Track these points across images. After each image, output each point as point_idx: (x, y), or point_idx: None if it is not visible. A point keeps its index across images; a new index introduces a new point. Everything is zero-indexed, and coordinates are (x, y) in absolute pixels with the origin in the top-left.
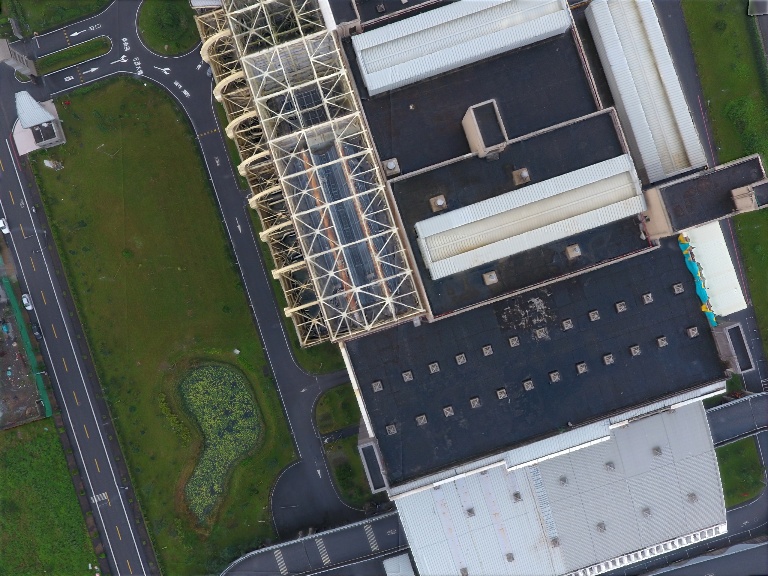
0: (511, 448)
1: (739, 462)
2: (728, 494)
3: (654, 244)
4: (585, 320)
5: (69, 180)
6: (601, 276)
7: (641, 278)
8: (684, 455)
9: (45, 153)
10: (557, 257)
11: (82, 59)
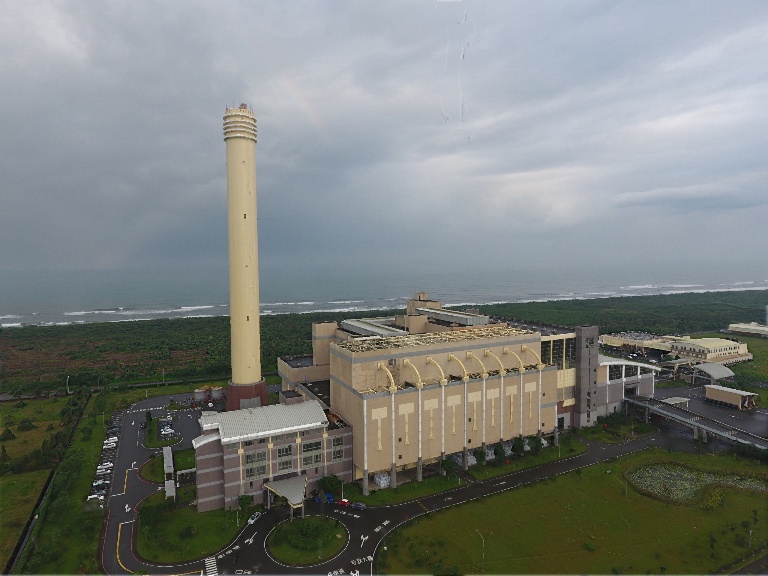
0: (545, 324)
1: None
2: None
3: None
4: None
5: None
6: None
7: None
8: None
9: None
10: None
11: None
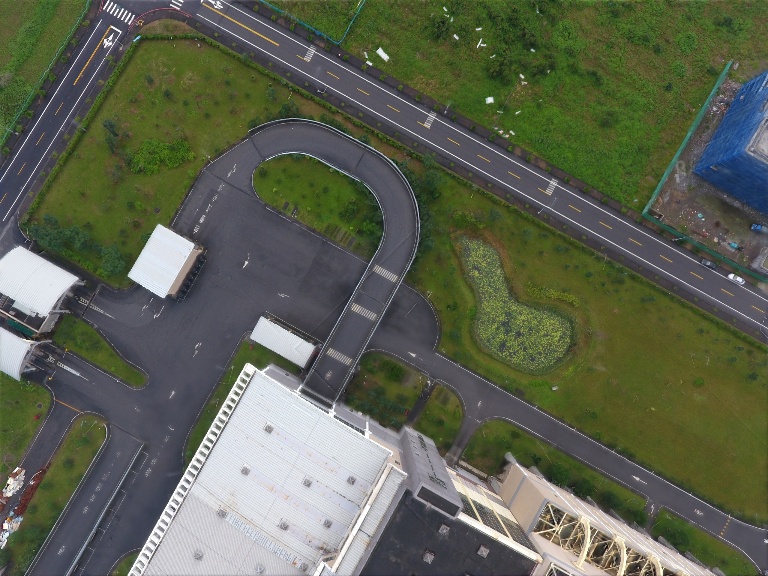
0: None
1: None
2: None
3: None
4: None
5: None
6: None
7: None
8: None
9: None
10: None
11: None
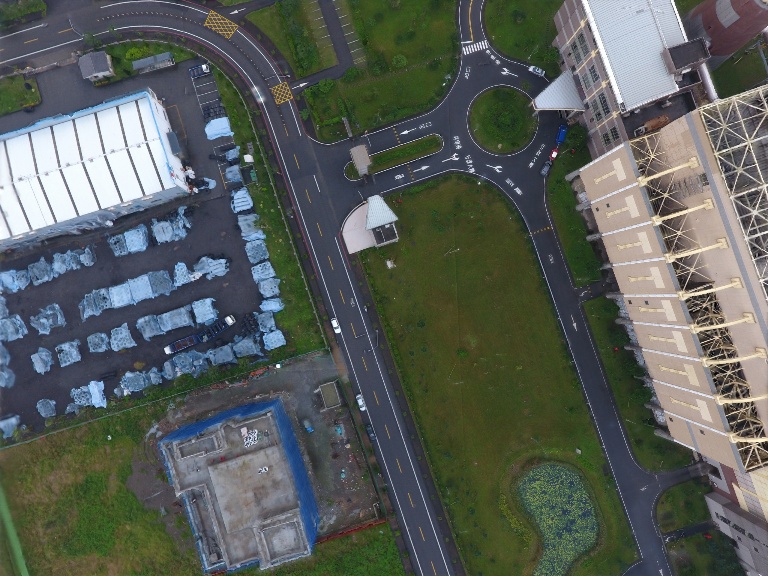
0: None
1: None
2: None
3: None
4: None
5: (401, 279)
6: None
7: None
8: None
9: (385, 254)
10: None
11: (413, 157)
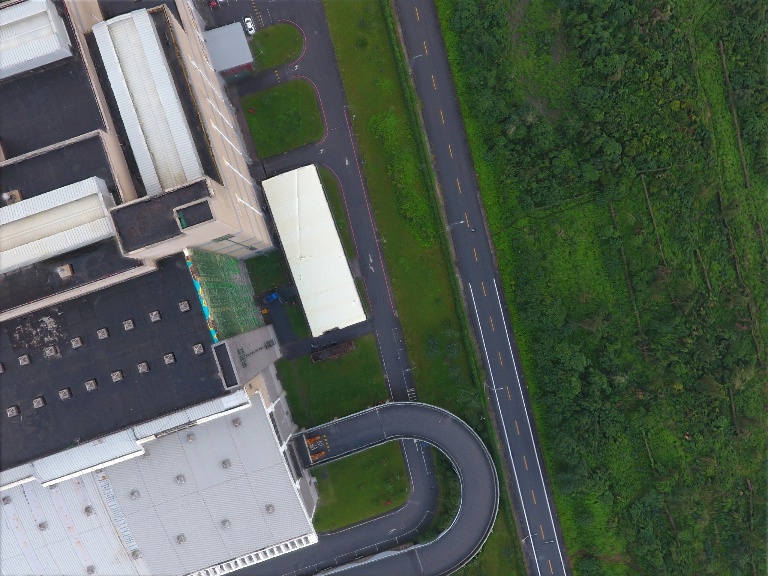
0: (18, 465)
1: (385, 471)
2: (373, 502)
3: (141, 264)
4: (95, 338)
5: None
6: (111, 295)
7: (149, 296)
8: (255, 467)
9: None
10: (51, 277)
11: None
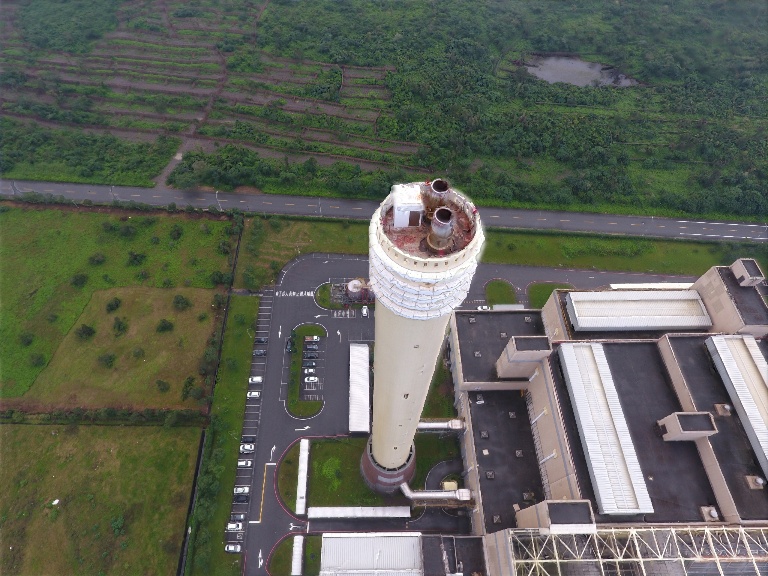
0: None
1: None
2: None
3: (766, 336)
4: None
5: None
6: None
7: None
8: None
9: None
10: None
11: None
